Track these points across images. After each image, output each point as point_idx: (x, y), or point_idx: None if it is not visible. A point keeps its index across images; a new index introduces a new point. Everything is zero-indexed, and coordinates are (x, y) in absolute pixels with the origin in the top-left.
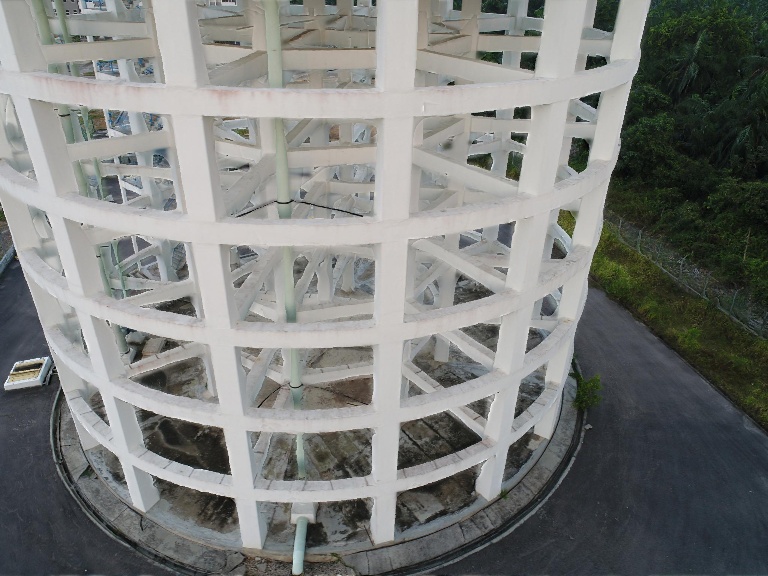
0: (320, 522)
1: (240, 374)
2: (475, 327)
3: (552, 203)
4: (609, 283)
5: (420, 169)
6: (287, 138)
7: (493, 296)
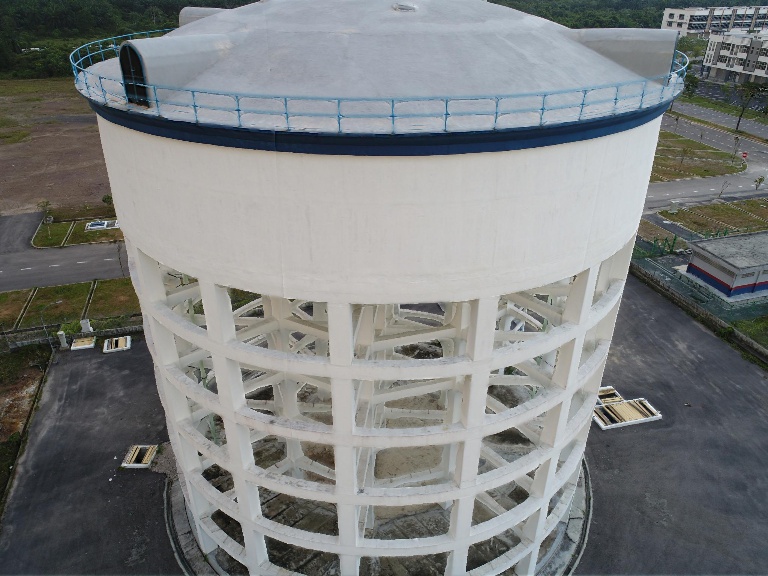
0: None
1: (177, 341)
2: (425, 556)
3: None
4: None
5: (277, 334)
6: None
7: None
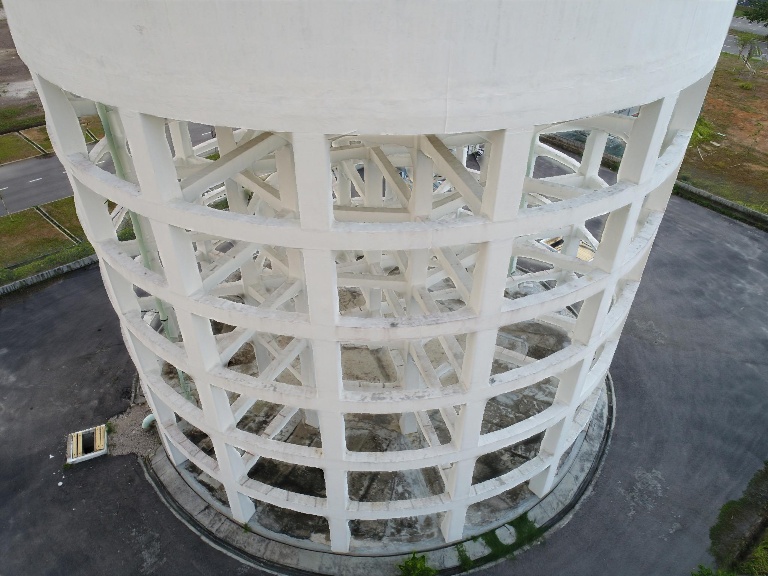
0: (181, 419)
1: None
2: None
3: (191, 307)
4: (745, 574)
5: None
6: (267, 156)
7: (179, 349)
